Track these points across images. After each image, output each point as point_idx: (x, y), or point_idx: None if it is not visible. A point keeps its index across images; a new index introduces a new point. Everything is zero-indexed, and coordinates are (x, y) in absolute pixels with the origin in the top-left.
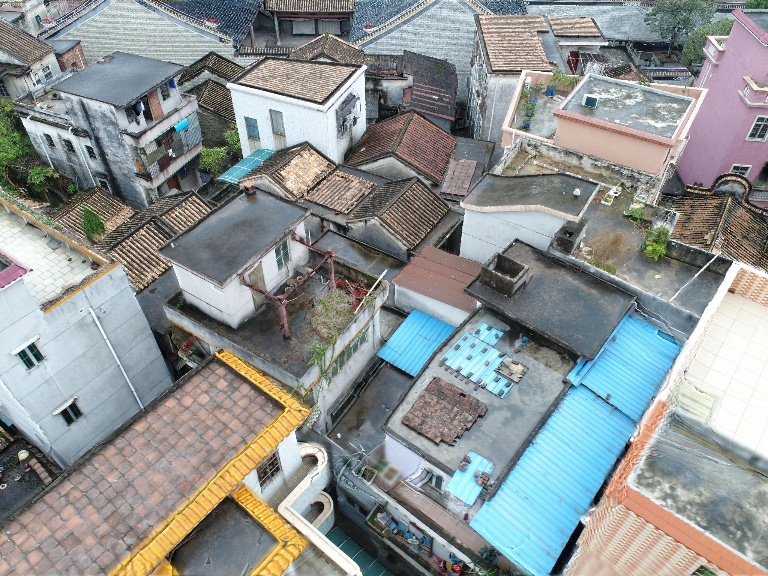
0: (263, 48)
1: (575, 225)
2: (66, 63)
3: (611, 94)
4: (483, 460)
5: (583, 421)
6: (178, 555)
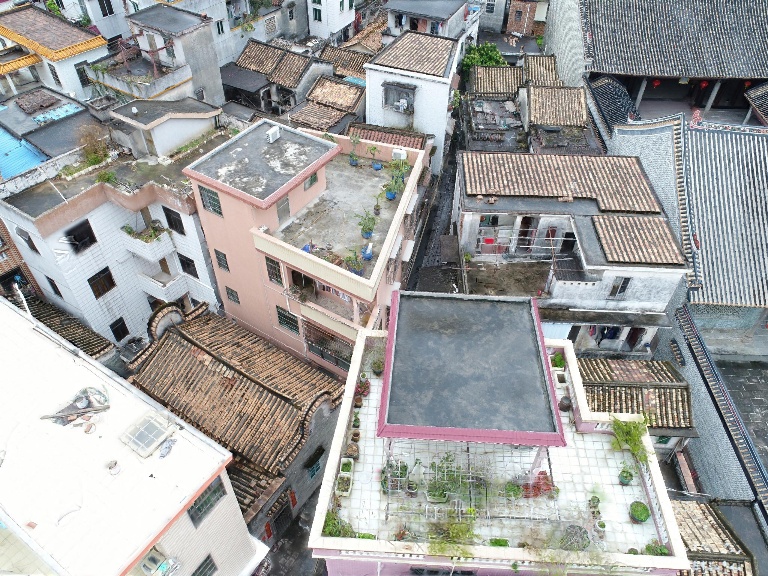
0: (612, 89)
1: (124, 127)
2: (512, 7)
3: (295, 155)
4: (0, 110)
5: (1, 147)
6: (20, 50)
